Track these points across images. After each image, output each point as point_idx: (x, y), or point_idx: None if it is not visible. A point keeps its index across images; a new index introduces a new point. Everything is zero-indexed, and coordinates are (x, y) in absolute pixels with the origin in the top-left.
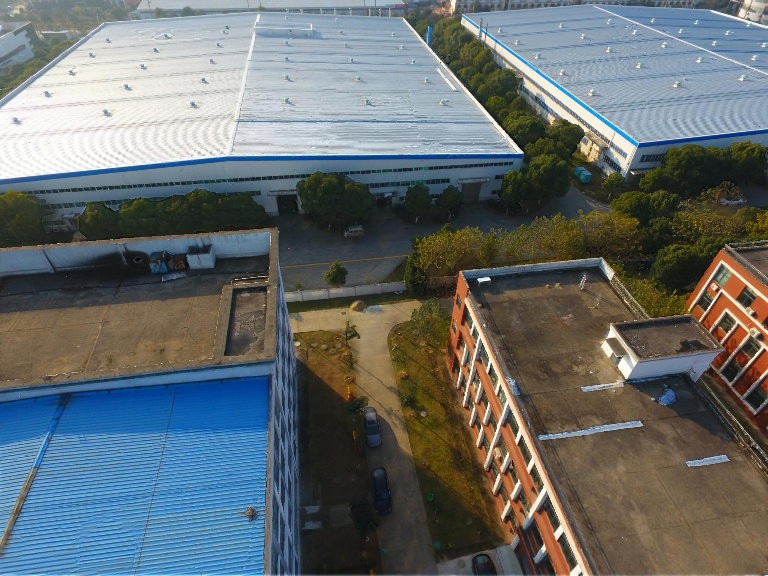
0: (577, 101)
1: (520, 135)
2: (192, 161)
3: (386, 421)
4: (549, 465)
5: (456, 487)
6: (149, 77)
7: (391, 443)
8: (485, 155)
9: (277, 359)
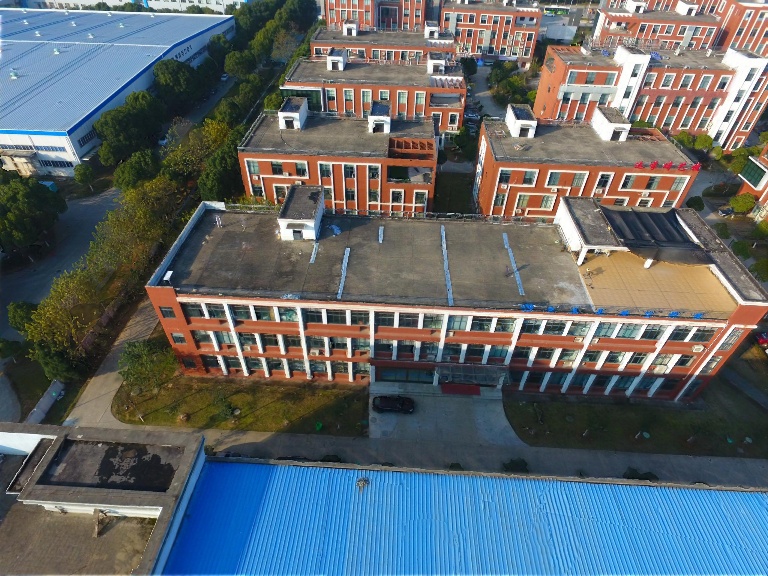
0: None
1: None
2: None
3: (228, 448)
4: (360, 301)
5: (316, 406)
6: None
7: (253, 448)
8: None
9: None
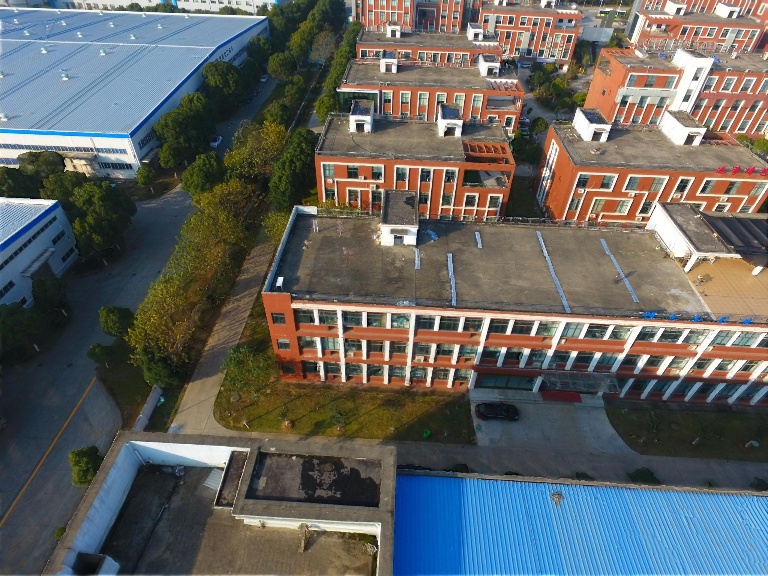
0: (4, 131)
1: (8, 192)
2: None
3: None
4: (476, 308)
5: (418, 412)
6: None
7: None
8: (24, 228)
9: None
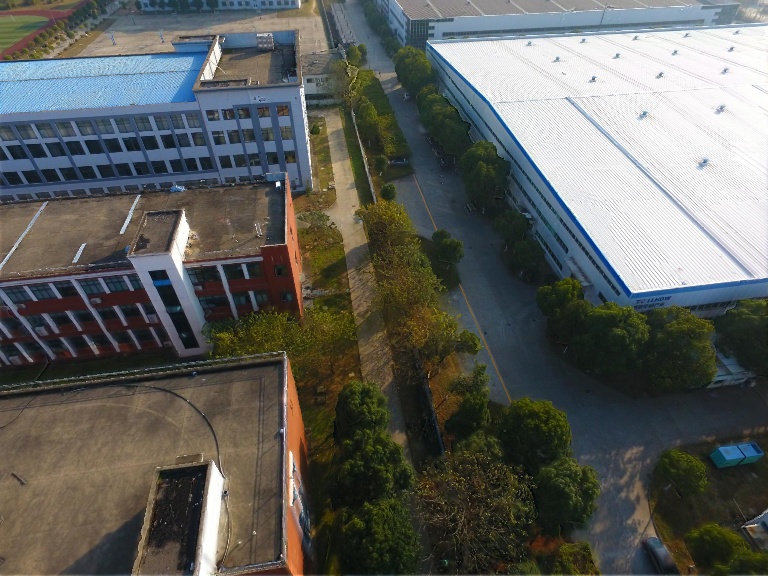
0: None
1: None
2: (478, 92)
3: None
4: (122, 195)
5: None
6: (652, 59)
7: None
8: (600, 252)
9: (224, 116)
